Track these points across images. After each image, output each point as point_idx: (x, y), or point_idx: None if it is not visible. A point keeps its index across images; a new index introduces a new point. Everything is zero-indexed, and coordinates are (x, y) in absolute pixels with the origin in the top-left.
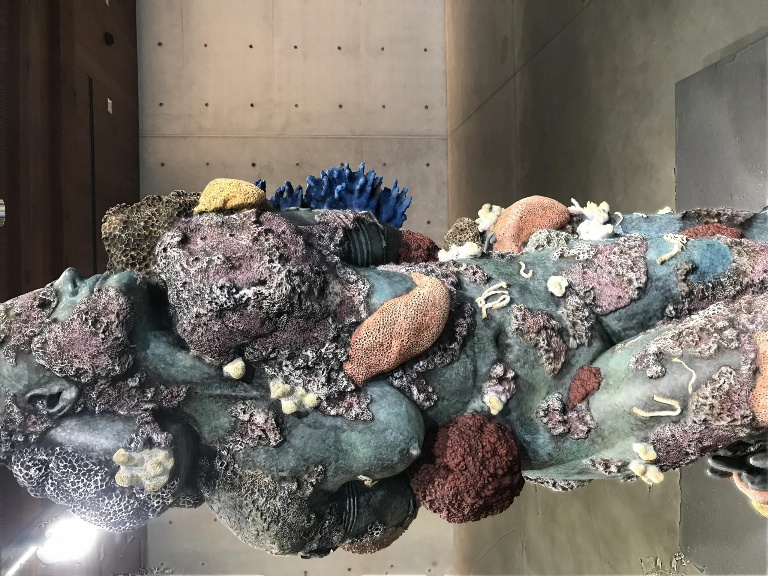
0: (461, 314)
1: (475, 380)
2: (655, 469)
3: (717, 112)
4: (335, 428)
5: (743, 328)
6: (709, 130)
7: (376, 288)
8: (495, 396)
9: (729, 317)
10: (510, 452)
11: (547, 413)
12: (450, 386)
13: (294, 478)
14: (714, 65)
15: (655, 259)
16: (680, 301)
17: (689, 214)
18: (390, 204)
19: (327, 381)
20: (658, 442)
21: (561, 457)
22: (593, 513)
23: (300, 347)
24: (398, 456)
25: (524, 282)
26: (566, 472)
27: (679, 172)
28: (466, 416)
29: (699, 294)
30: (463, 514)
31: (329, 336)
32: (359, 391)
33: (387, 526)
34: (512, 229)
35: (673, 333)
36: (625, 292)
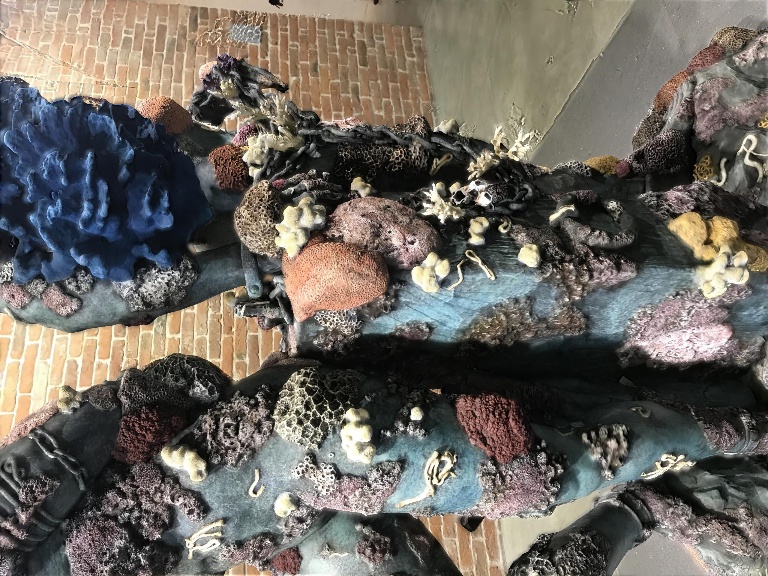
0: (160, 573)
1: None
2: None
3: None
4: None
5: None
6: None
7: None
8: None
9: None
10: None
11: None
12: None
13: None
14: None
15: (395, 503)
16: None
17: (552, 277)
18: (142, 216)
19: None
20: None
21: None
22: (499, 28)
23: None
24: None
25: (249, 505)
26: None
27: None
28: None
29: None
30: None
31: None
32: None
33: None
34: (302, 305)
35: None
36: None
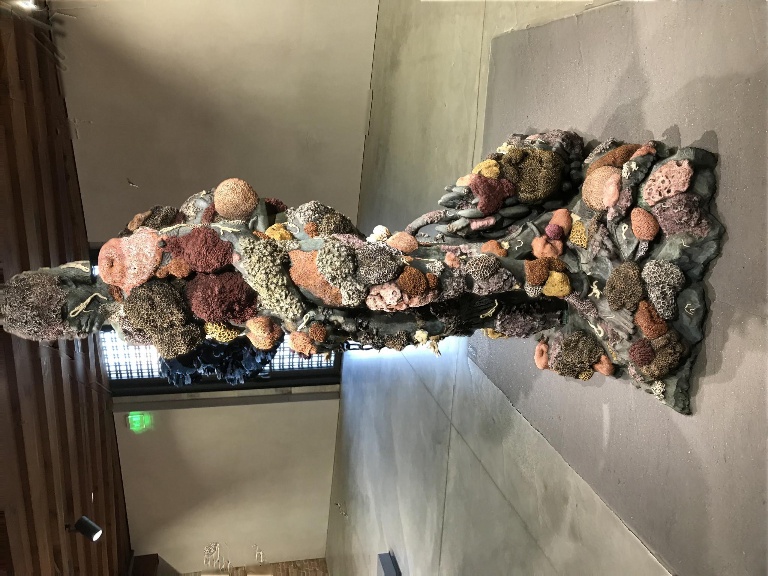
0: None
1: None
2: None
3: (730, 568)
4: None
5: None
6: (756, 570)
7: None
8: None
9: None
10: None
11: None
12: None
13: None
14: None
15: None
16: None
17: None
18: None
19: None
20: None
21: None
22: None
23: None
24: None
25: None
26: None
27: None
28: None
29: None
30: None
31: None
32: None
33: None
34: None
35: None
36: None
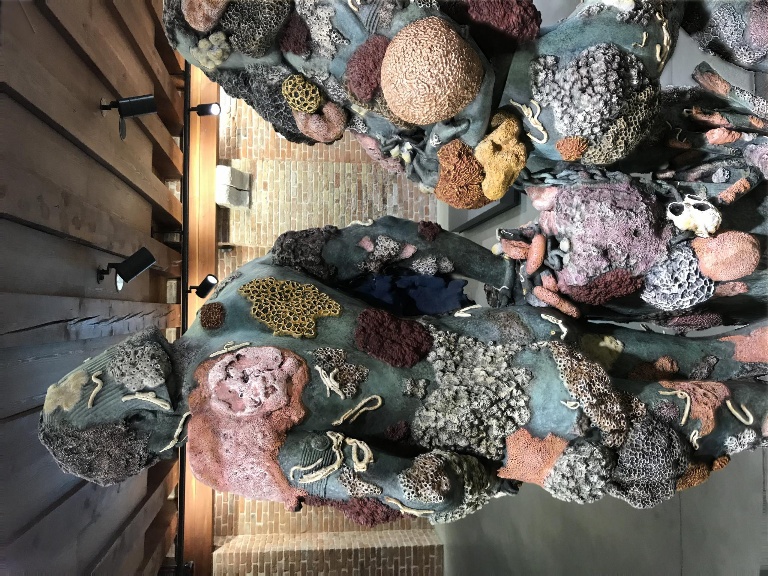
0: None
1: None
2: None
3: None
4: None
5: None
6: None
7: None
8: None
9: None
10: None
11: None
12: None
13: None
14: (767, 536)
15: None
16: None
17: None
18: None
19: None
20: None
21: None
22: None
23: None
24: None
25: None
26: None
27: None
28: None
29: None
30: None
31: None
32: None
33: (442, 14)
34: None
35: None
36: None
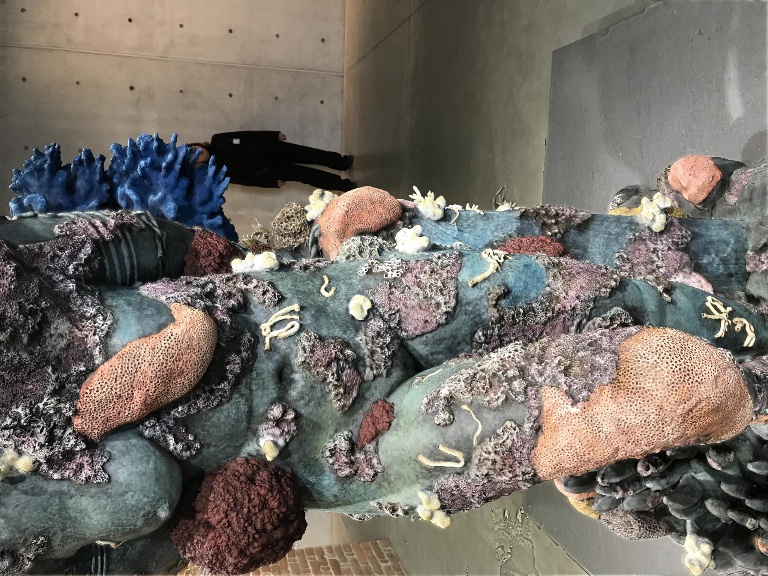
0: (236, 347)
1: (250, 422)
2: (442, 514)
3: (587, 86)
4: (60, 493)
5: (532, 380)
6: (579, 104)
7: (120, 324)
8: (270, 441)
9: (521, 365)
10: (283, 503)
11: (334, 453)
12: (217, 431)
13: (5, 554)
14: (588, 37)
15: (467, 281)
16: (490, 326)
17: (527, 213)
18: (205, 185)
19: (48, 440)
20: (442, 491)
21: (348, 498)
22: None
23: (8, 403)
24: (142, 520)
25: (322, 302)
26: (355, 511)
27: (549, 143)
28: (238, 461)
29: (509, 320)
30: (227, 571)
31: (47, 389)
32: (94, 448)
33: (153, 574)
34: (337, 224)
35: (468, 374)
36: (432, 316)
